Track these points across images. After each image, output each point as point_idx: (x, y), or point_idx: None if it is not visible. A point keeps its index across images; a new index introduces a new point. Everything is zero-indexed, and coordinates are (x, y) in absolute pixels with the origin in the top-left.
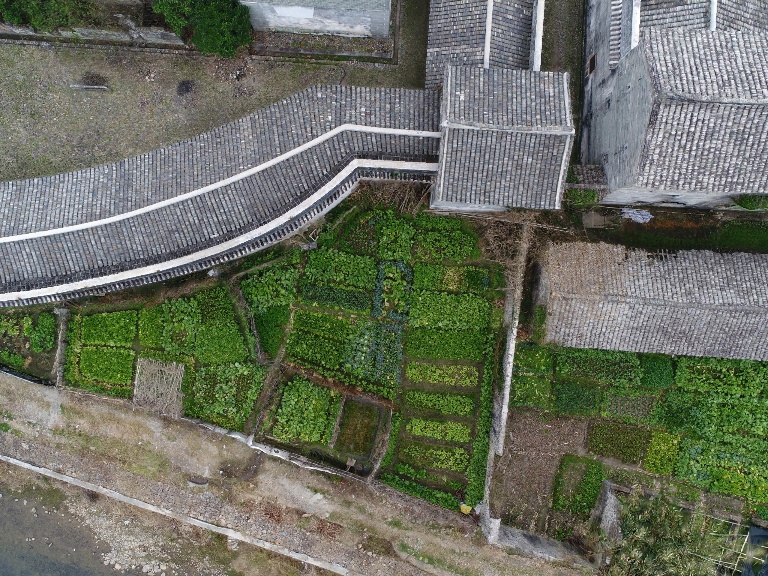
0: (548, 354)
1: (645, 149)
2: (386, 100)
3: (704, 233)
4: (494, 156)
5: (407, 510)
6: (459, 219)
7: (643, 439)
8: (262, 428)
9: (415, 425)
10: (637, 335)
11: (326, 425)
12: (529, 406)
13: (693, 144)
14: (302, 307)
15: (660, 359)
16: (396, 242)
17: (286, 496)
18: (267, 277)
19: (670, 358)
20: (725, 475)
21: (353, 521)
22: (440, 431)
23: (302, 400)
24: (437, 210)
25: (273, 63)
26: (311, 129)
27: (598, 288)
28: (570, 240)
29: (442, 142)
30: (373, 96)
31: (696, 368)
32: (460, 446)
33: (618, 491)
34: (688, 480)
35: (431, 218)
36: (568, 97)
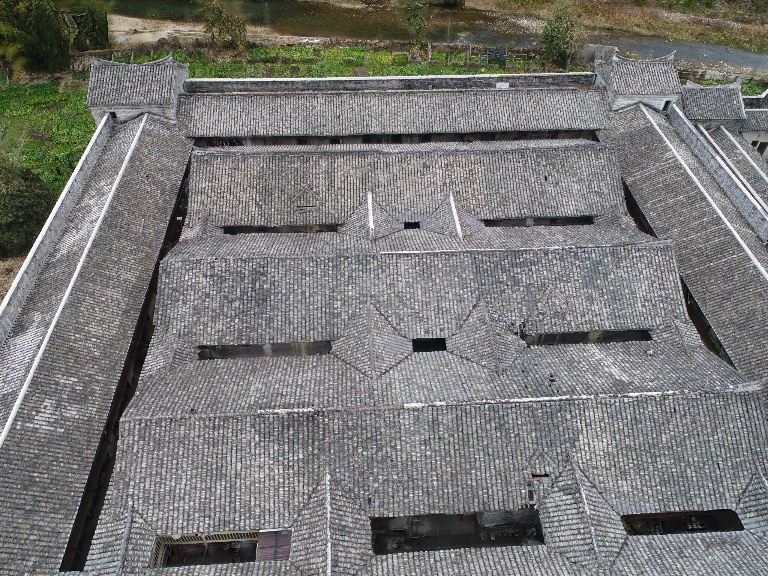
0: None
1: None
2: (762, 124)
3: None
4: None
5: None
6: None
7: None
8: None
9: None
10: None
11: None
12: None
13: None
14: None
15: None
16: None
17: None
18: None
19: None
20: None
21: None
22: None
23: None
24: None
25: None
26: None
27: None
28: None
29: None
30: None
31: None
32: None
33: None
34: None
35: None
36: None
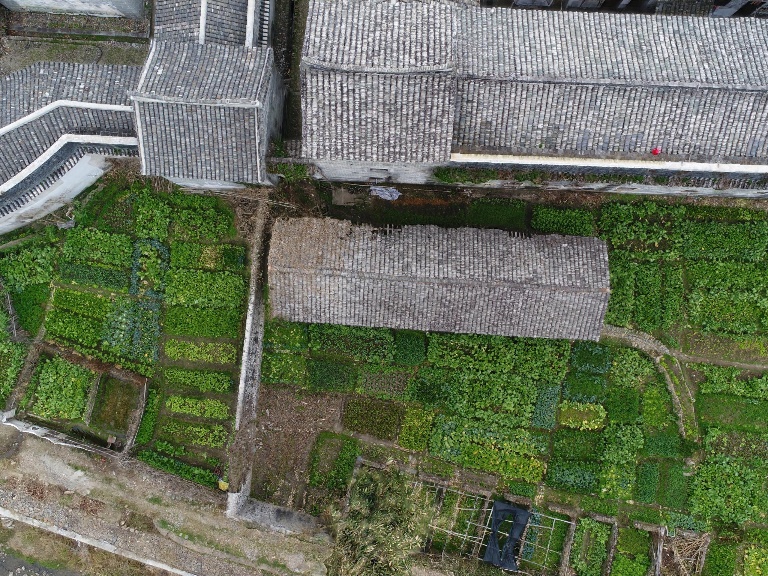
0: (302, 331)
1: (303, 119)
2: (107, 77)
3: (453, 210)
4: (189, 130)
5: (167, 487)
6: (214, 197)
7: (398, 415)
8: (23, 406)
9: (174, 402)
10: (361, 309)
11: (86, 402)
12: (286, 383)
13: (349, 114)
14: (62, 285)
15: (413, 336)
16: (153, 220)
17: (47, 473)
18: (23, 255)
19: (423, 335)
20: (476, 450)
21: (114, 498)
22: (199, 408)
23: (61, 378)
24: (191, 188)
25: (30, 43)
26: (28, 105)
27: (315, 262)
28: (301, 216)
29: (135, 116)
30: (95, 73)
31: (450, 345)
32: (220, 423)
33: (369, 466)
34: (442, 456)
35: (186, 196)
36: (264, 71)
